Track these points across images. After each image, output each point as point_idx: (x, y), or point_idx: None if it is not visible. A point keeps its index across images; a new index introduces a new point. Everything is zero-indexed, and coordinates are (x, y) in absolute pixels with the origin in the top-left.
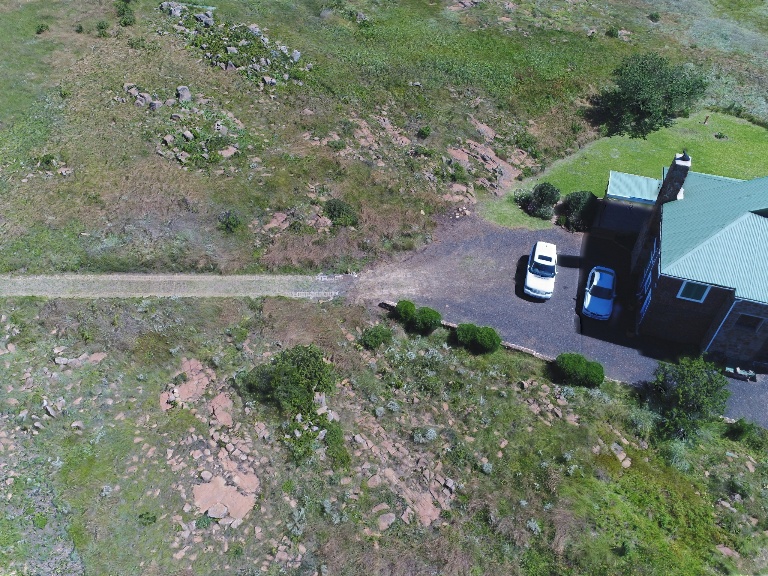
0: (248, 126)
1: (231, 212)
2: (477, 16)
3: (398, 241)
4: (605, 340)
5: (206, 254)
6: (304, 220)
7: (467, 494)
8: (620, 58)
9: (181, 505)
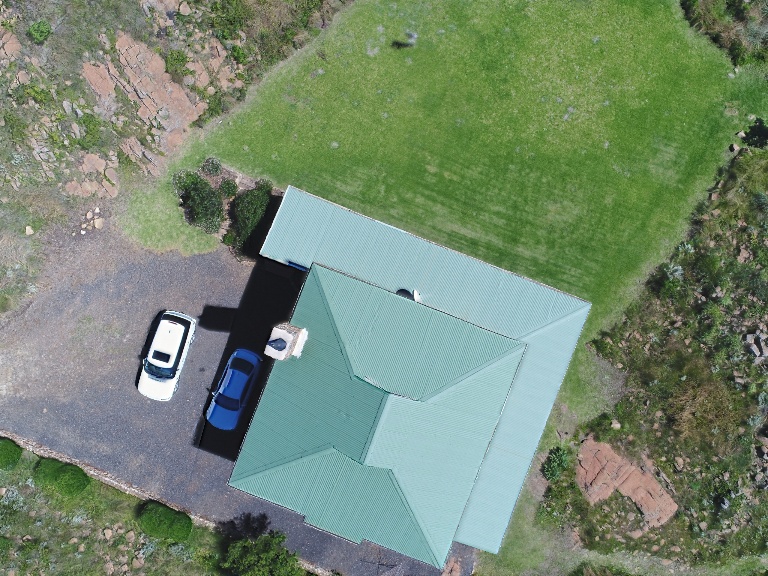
0: None
1: None
2: None
3: None
4: (224, 457)
5: None
6: None
7: None
8: None
9: None
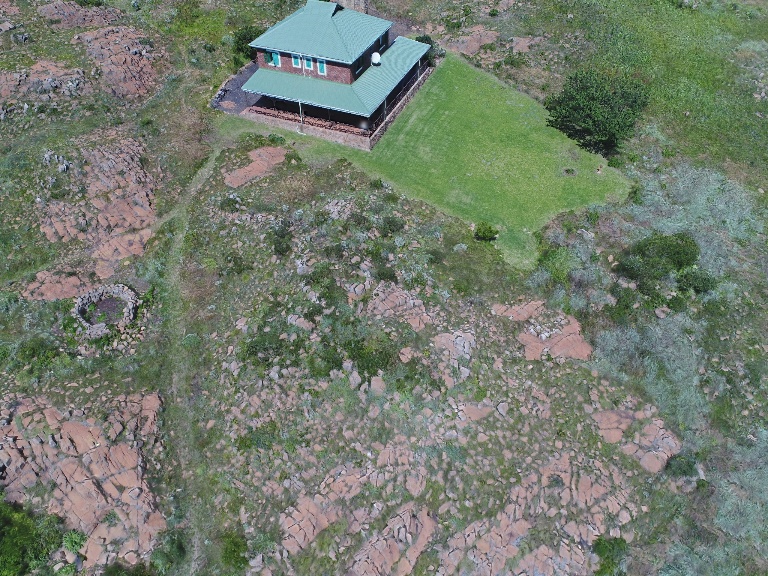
0: None
1: None
2: (767, 61)
3: (382, 5)
4: None
5: None
6: None
7: None
8: (766, 165)
9: None
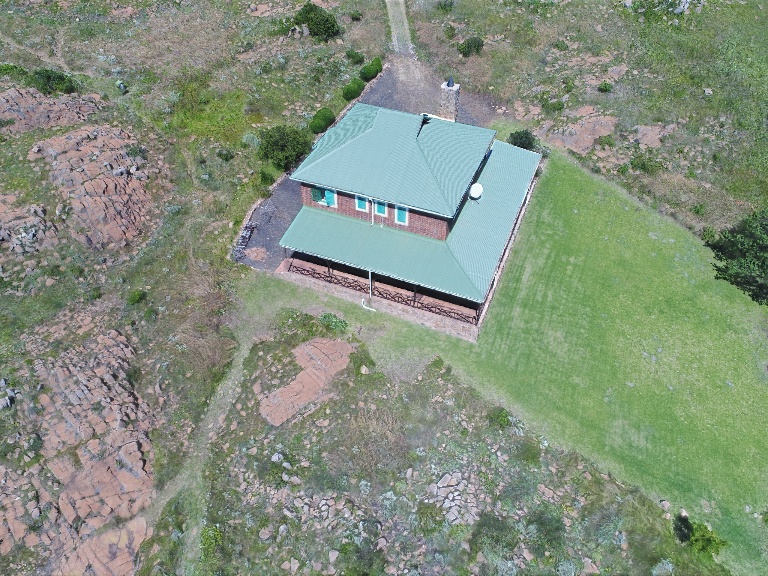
0: (562, 6)
1: (449, 0)
2: None
3: (452, 74)
4: None
5: (415, 1)
6: (459, 33)
7: None
8: None
9: (259, 2)
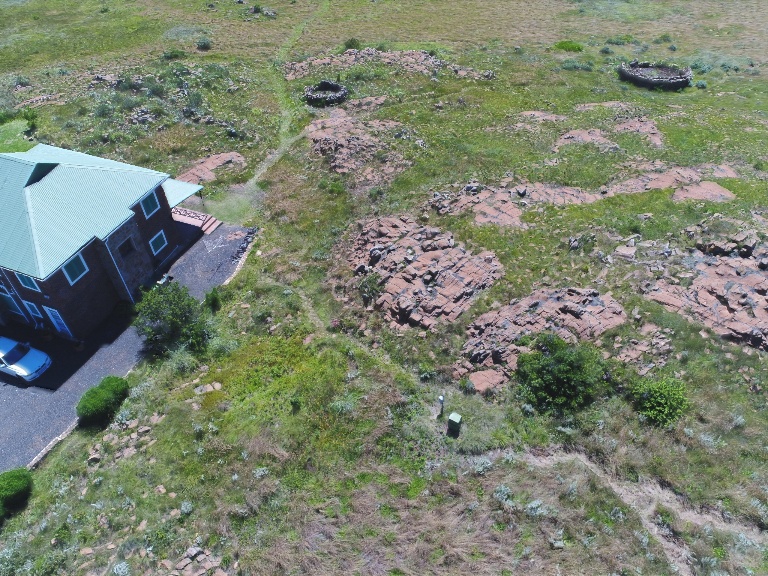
0: None
1: None
2: None
3: None
4: (75, 371)
5: None
6: None
7: (210, 534)
8: None
9: None
